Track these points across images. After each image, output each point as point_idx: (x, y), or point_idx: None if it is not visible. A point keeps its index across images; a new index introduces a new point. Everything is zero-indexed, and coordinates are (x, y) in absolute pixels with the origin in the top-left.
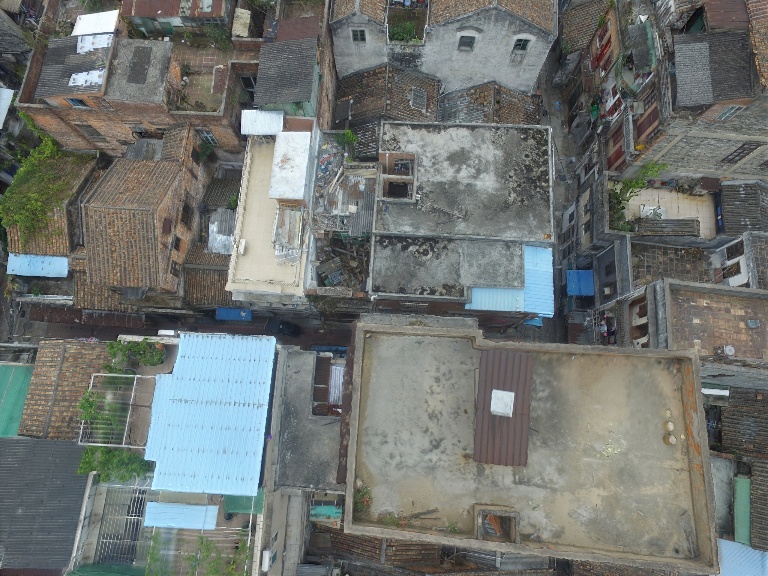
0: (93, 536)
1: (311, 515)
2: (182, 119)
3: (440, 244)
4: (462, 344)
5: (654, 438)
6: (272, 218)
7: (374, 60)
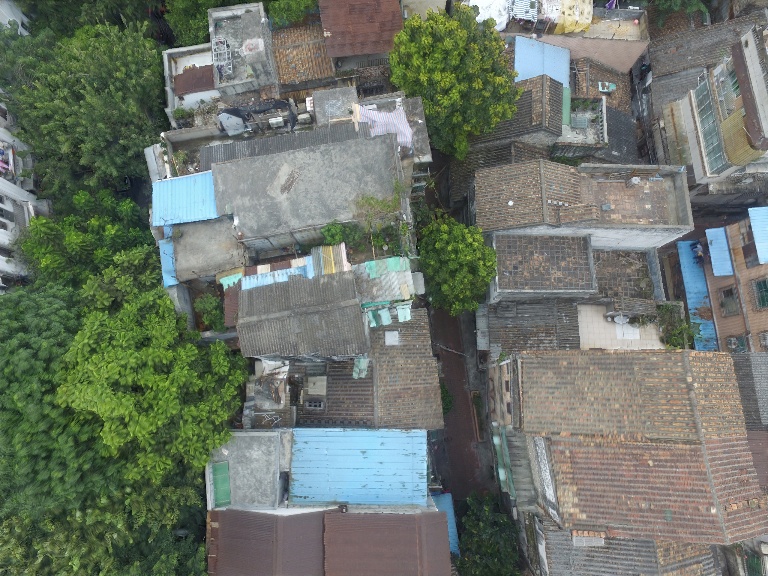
0: None
1: None
2: None
3: None
4: None
5: None
6: None
7: None
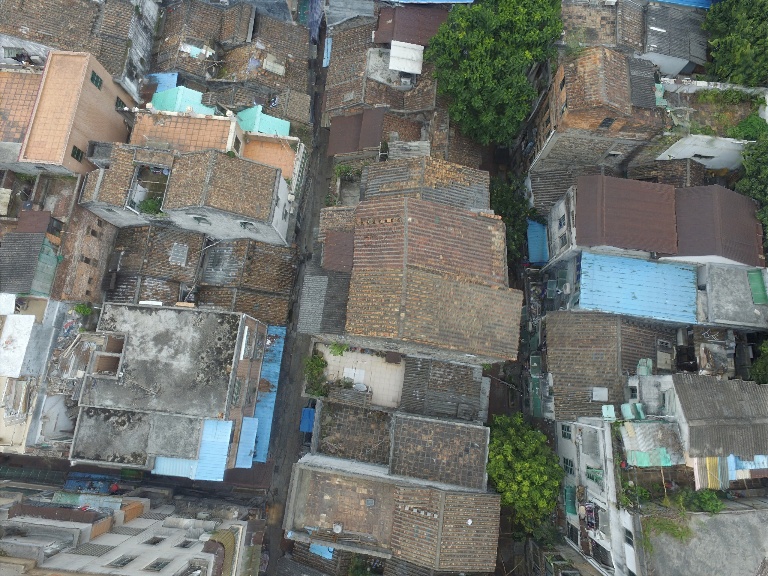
0: None
1: None
2: None
3: (136, 416)
4: None
5: None
6: None
7: (137, 221)
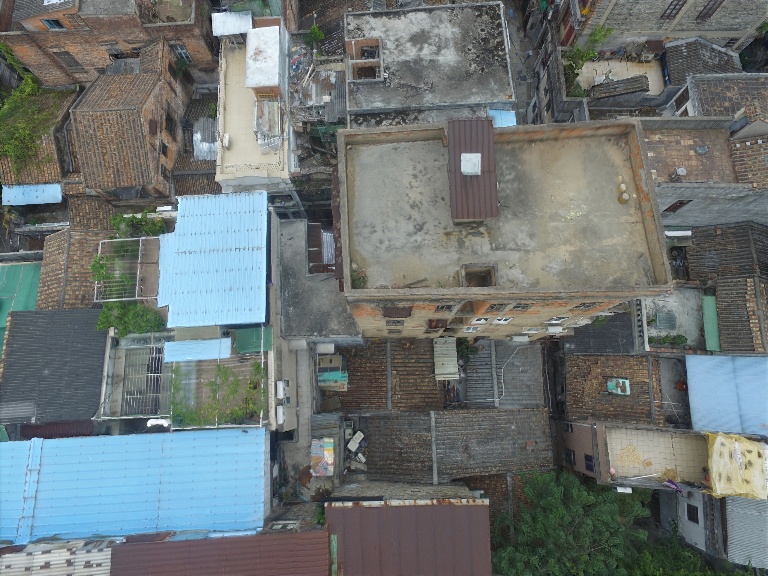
0: (117, 394)
1: (319, 381)
2: (156, 33)
3: (411, 116)
4: (434, 145)
5: (610, 200)
6: (252, 114)
7: None
